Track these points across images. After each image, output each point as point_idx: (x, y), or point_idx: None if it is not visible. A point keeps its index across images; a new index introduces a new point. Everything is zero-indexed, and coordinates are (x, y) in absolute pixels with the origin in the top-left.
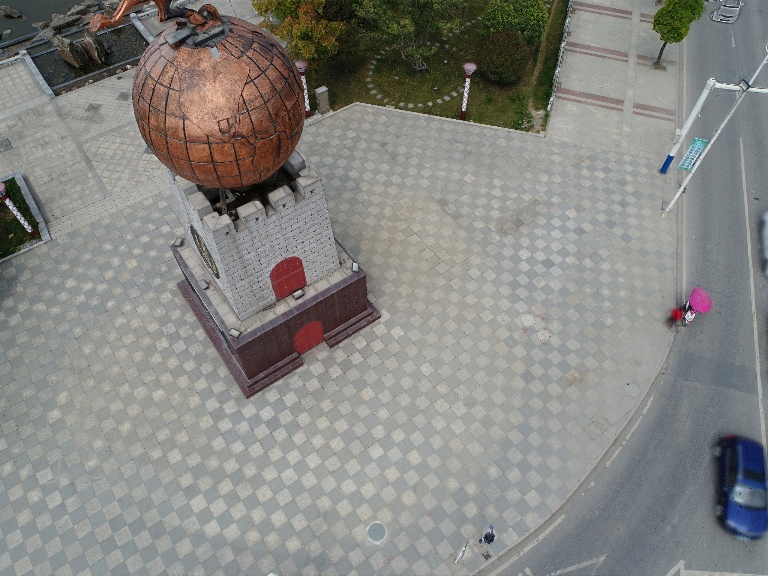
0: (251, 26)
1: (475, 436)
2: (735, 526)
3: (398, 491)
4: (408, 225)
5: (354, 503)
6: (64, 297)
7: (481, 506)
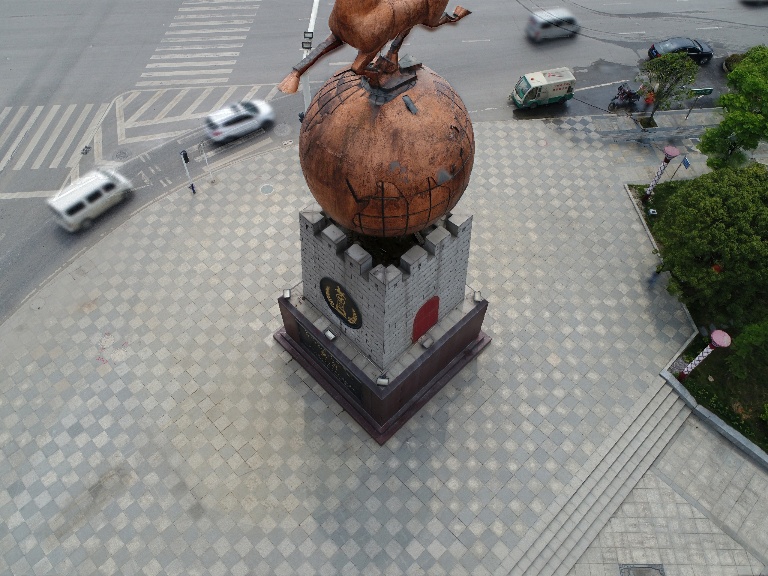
0: (347, 113)
1: (190, 250)
2: (4, 222)
3: (253, 211)
4: (246, 463)
5: (284, 201)
6: (596, 315)
7: (191, 210)
